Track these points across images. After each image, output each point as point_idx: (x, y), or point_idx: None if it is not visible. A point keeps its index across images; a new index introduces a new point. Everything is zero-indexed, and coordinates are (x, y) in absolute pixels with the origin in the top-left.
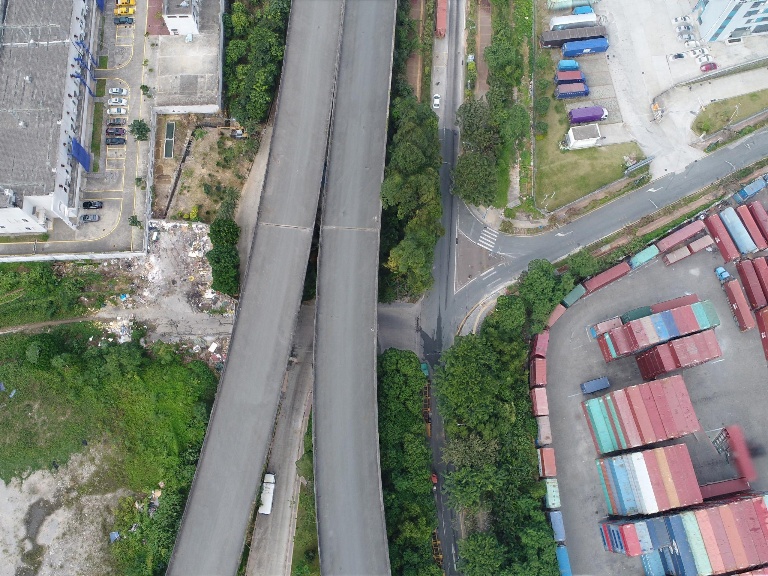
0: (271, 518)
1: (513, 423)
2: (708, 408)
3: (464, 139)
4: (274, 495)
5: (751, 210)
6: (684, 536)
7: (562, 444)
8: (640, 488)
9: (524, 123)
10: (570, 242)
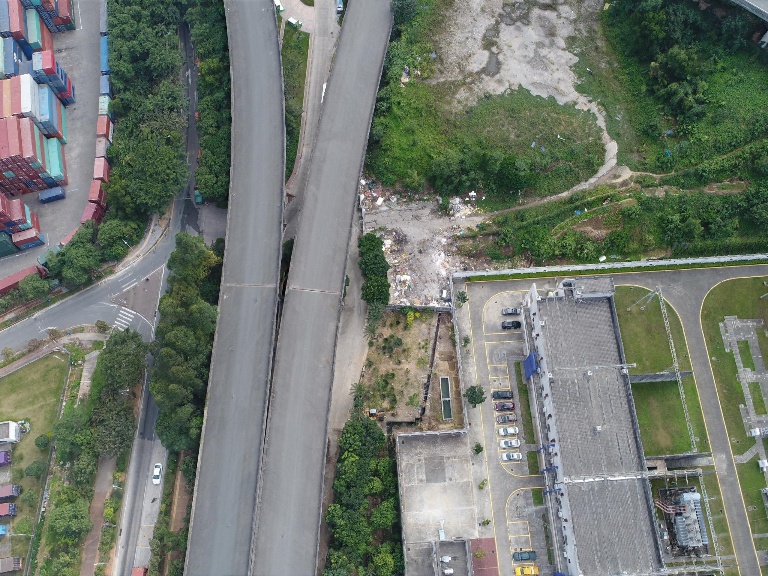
0: None
1: None
2: None
3: None
4: None
5: None
6: (7, 61)
7: (92, 154)
8: None
9: None
10: (44, 321)
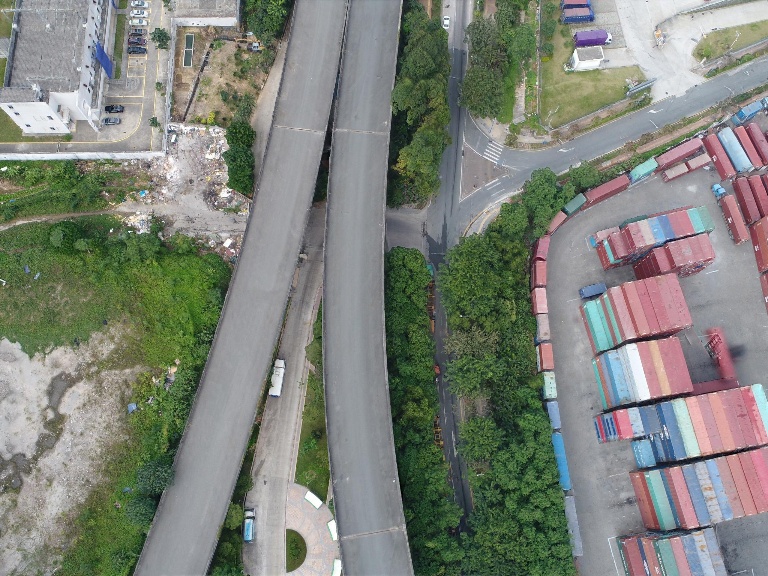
0: (280, 401)
1: (513, 321)
2: (701, 315)
3: (472, 55)
4: (284, 380)
5: (748, 131)
6: (674, 421)
7: (560, 345)
8: (633, 376)
9: (530, 41)
10: (572, 157)
